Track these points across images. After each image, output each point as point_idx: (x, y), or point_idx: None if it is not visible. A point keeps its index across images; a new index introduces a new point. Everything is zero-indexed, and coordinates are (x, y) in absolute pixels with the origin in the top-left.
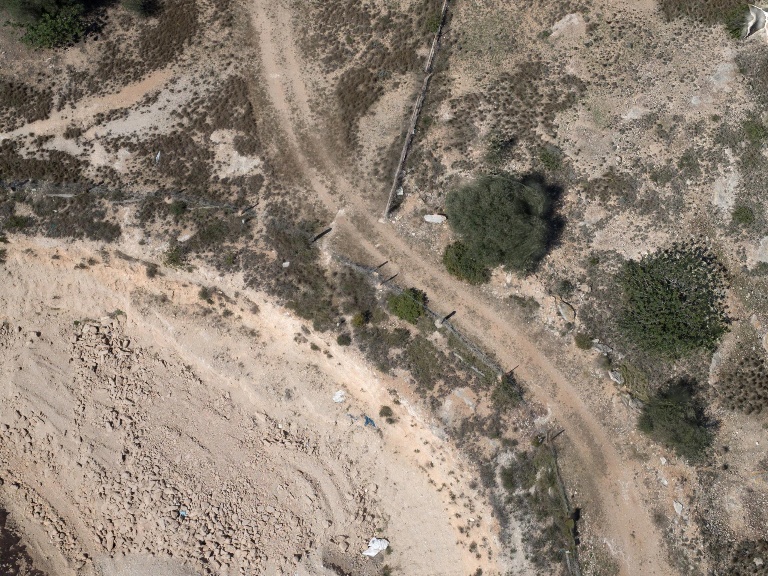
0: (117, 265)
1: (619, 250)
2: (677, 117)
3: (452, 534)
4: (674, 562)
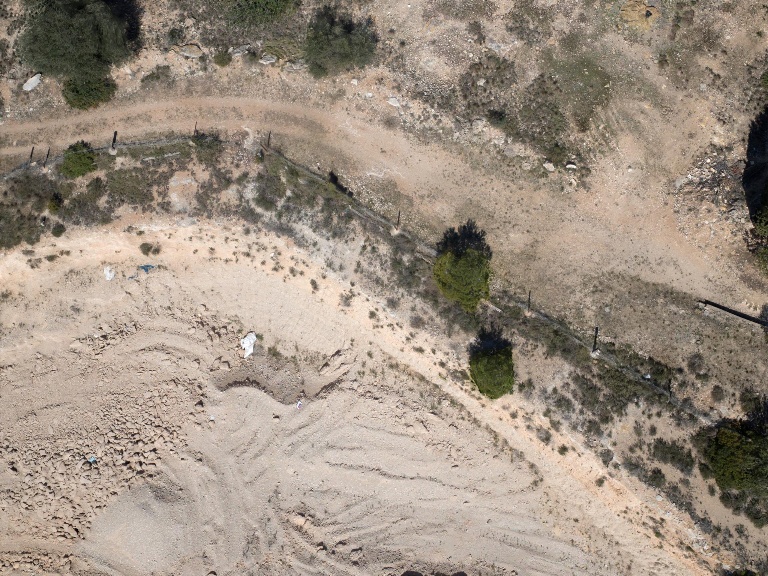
0: None
1: None
2: None
3: (277, 280)
4: (426, 140)
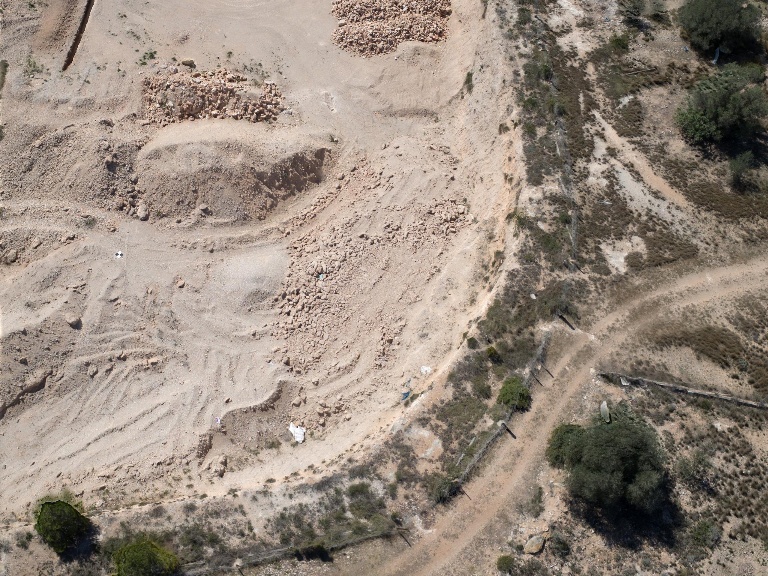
0: (511, 196)
1: None
2: None
3: None
4: None
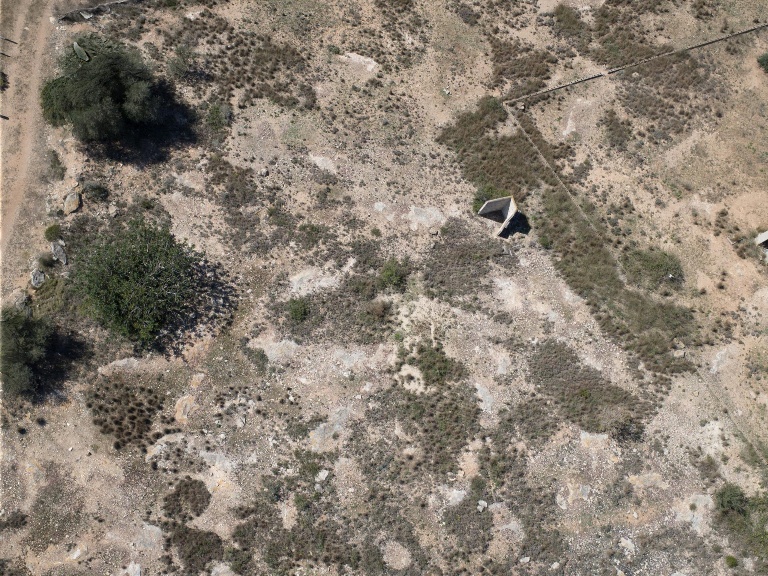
0: None
1: (175, 220)
2: (349, 199)
3: None
4: None
